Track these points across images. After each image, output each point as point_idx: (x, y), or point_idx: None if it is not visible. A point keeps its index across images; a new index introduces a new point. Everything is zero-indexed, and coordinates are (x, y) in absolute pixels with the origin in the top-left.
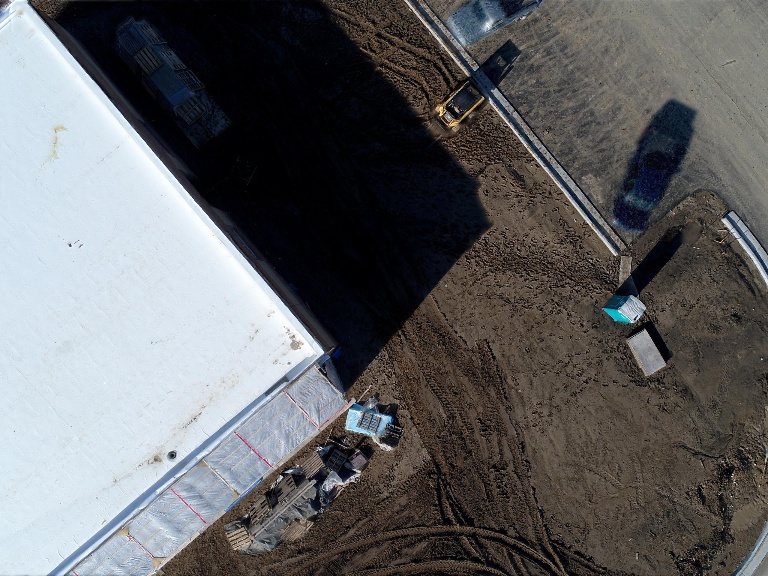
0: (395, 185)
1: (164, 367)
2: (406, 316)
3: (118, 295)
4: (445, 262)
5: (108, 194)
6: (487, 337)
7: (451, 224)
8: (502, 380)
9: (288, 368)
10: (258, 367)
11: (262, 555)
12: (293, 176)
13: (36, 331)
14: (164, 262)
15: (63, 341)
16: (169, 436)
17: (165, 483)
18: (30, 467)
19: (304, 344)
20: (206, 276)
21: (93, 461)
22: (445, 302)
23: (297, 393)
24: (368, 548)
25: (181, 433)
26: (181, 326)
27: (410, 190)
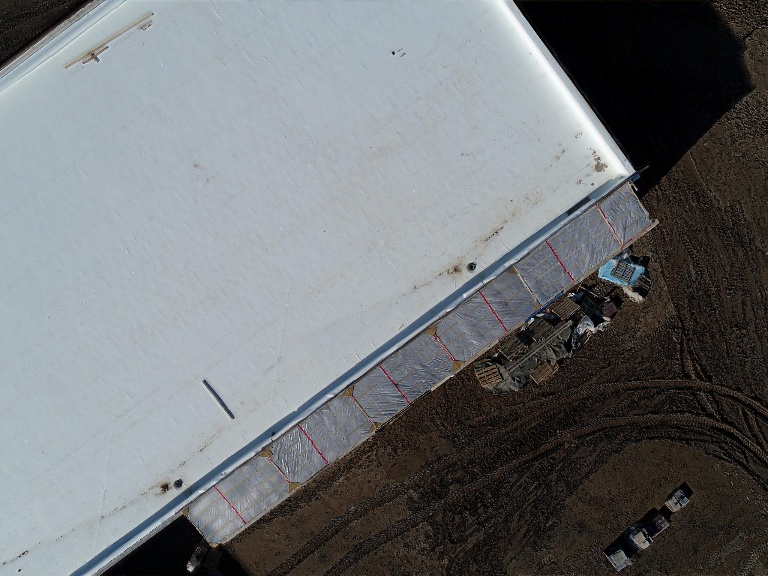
0: (665, 42)
1: (472, 179)
2: (664, 171)
3: (435, 105)
4: (706, 121)
5: (434, 6)
6: (740, 198)
7: (715, 84)
8: (751, 242)
9: (591, 189)
10: (562, 186)
11: (507, 395)
12: (567, 26)
13: (354, 135)
14: (481, 76)
15: (378, 146)
16: (470, 248)
17: (473, 287)
18: (336, 267)
19: (608, 167)
20: (520, 93)
21: (396, 266)
22: (703, 160)
23: (608, 208)
24: (609, 396)
25: (482, 245)
26: (492, 140)
27: (679, 48)
